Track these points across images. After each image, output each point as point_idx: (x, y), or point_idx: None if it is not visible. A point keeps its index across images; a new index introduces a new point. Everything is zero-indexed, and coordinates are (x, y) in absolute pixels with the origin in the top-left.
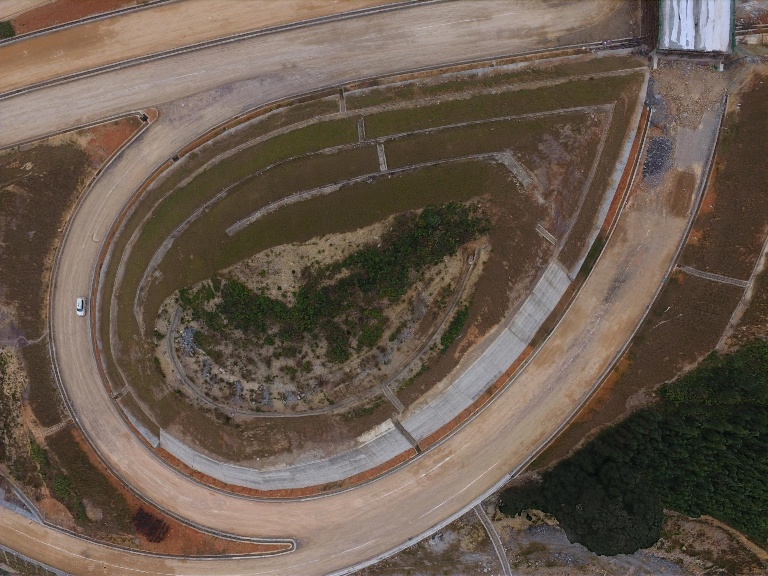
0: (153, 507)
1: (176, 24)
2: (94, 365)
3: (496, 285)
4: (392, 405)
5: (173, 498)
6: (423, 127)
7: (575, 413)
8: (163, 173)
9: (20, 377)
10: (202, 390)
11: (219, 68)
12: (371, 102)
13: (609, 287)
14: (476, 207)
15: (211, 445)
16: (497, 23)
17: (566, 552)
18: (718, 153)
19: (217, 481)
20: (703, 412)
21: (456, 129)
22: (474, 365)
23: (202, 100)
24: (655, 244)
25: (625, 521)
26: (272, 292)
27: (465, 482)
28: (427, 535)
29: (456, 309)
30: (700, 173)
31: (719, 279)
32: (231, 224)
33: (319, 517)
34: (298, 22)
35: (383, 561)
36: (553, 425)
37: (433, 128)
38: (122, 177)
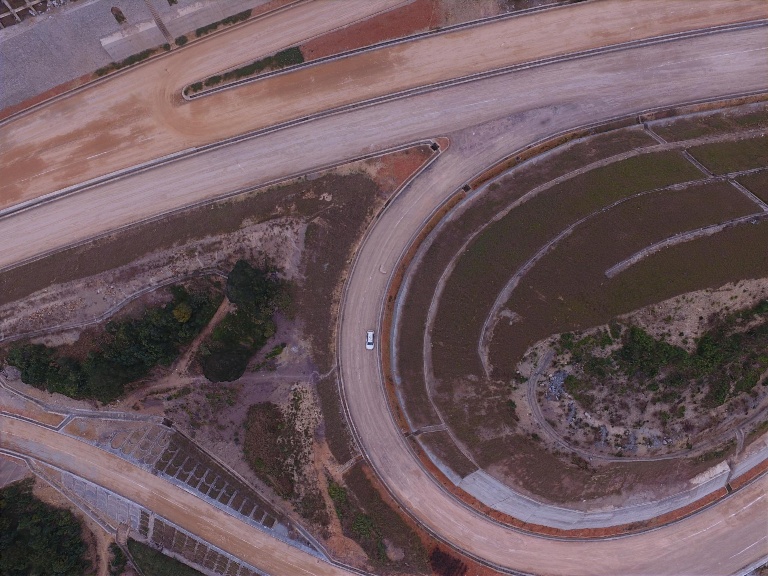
0: (448, 546)
1: (468, 50)
2: (382, 400)
3: None
4: (736, 447)
5: (467, 537)
6: None
7: None
8: (462, 204)
9: (314, 413)
10: (562, 434)
11: (511, 96)
12: (689, 133)
13: None
14: None
15: (540, 487)
16: None
17: None
18: None
19: (516, 520)
20: None
21: None
22: None
23: (494, 128)
24: None
25: None
26: (672, 338)
27: None
28: None
29: None
30: None
31: None
32: (611, 266)
33: (622, 557)
34: (595, 49)
35: None
36: None
37: None
38: (410, 207)
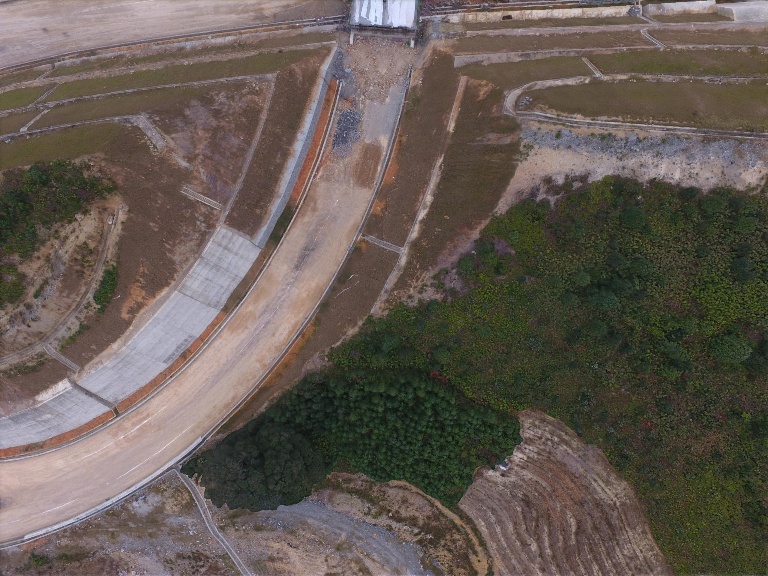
0: None
1: None
2: None
3: (148, 246)
4: (61, 364)
5: None
6: (92, 93)
7: (264, 378)
8: None
9: None
10: None
11: None
12: (70, 71)
13: (299, 255)
14: (88, 165)
15: None
16: None
17: (275, 517)
18: (401, 126)
19: None
20: (367, 375)
21: (123, 95)
22: (146, 327)
23: None
24: (343, 214)
25: (238, 474)
26: None
27: (160, 444)
28: (122, 496)
29: (103, 268)
30: (386, 145)
31: (388, 247)
32: None
33: (22, 478)
34: None
35: (86, 522)
36: (244, 389)
37: (101, 94)
38: None
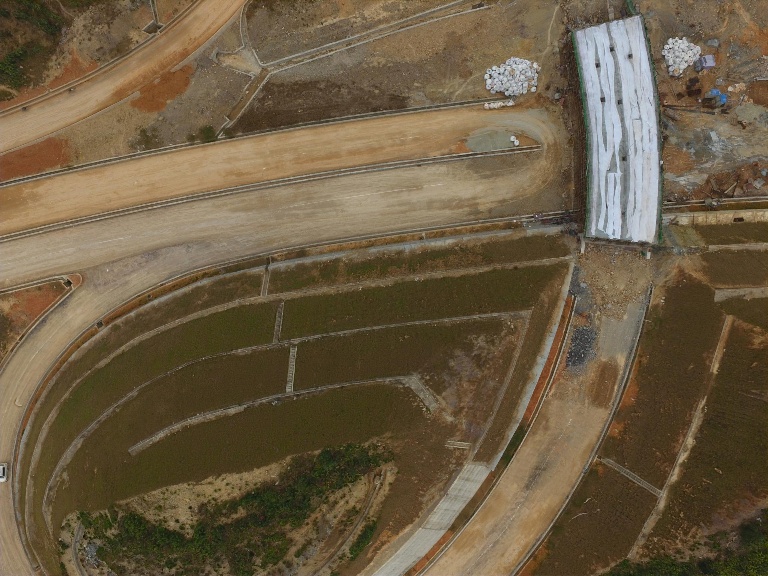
0: None
1: (101, 188)
2: (16, 531)
3: (406, 497)
4: None
5: None
6: (338, 329)
7: None
8: (85, 344)
9: None
10: None
11: (145, 233)
12: (293, 284)
13: (530, 474)
14: (376, 446)
15: None
16: (428, 193)
17: None
18: (641, 346)
19: None
20: None
21: (371, 332)
22: (388, 563)
23: (127, 266)
24: (577, 433)
25: None
26: (170, 524)
27: None
28: None
29: (364, 524)
30: (623, 364)
31: (636, 480)
32: (134, 444)
33: None
34: (225, 189)
35: None
36: None
37: (348, 331)
38: (45, 342)
